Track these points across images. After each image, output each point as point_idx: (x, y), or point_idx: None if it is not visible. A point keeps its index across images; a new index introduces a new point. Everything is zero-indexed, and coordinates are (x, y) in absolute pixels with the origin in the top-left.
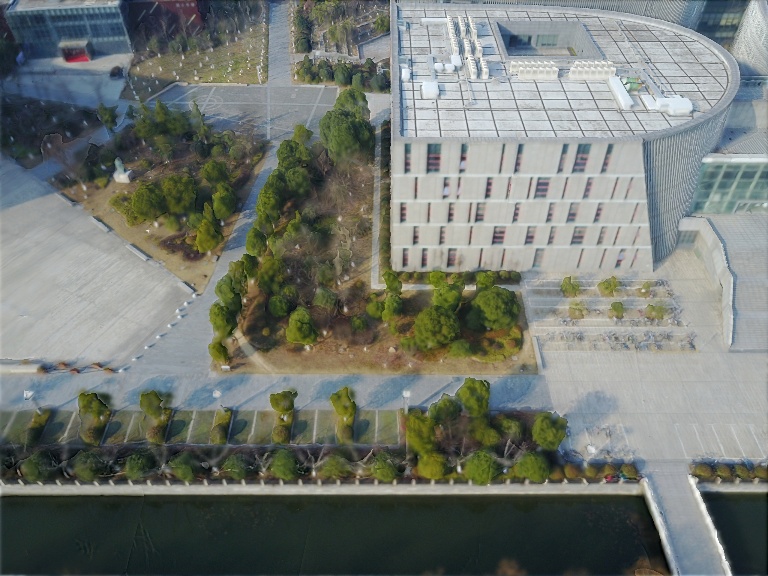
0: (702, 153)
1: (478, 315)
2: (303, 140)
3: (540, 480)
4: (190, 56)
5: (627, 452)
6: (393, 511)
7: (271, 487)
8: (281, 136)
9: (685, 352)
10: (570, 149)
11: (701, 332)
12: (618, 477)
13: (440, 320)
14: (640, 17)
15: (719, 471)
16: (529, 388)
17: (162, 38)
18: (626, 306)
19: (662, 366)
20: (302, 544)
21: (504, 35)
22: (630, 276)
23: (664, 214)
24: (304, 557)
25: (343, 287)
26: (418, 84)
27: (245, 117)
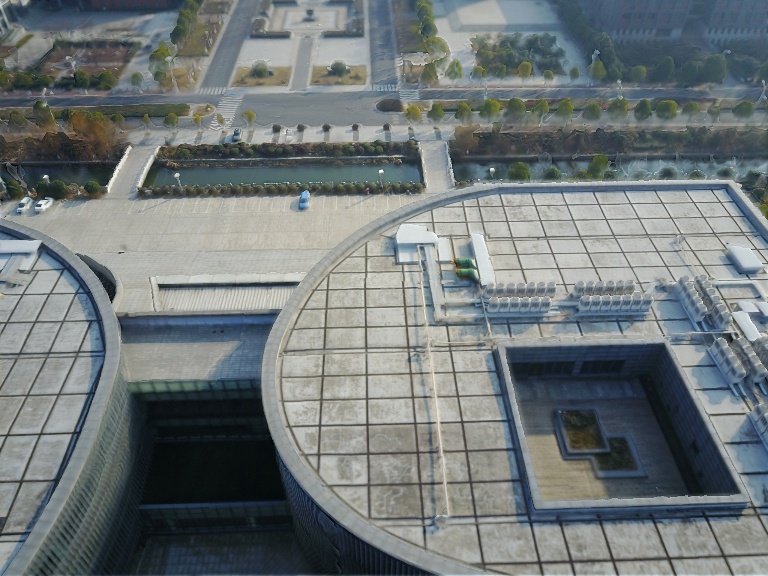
0: None
1: None
2: None
3: None
4: None
5: None
6: None
7: None
8: None
9: None
10: None
11: None
12: (471, 180)
13: None
14: (380, 533)
15: None
16: None
17: None
18: None
19: None
20: None
21: None
22: None
23: None
24: None
25: None
26: None
27: None
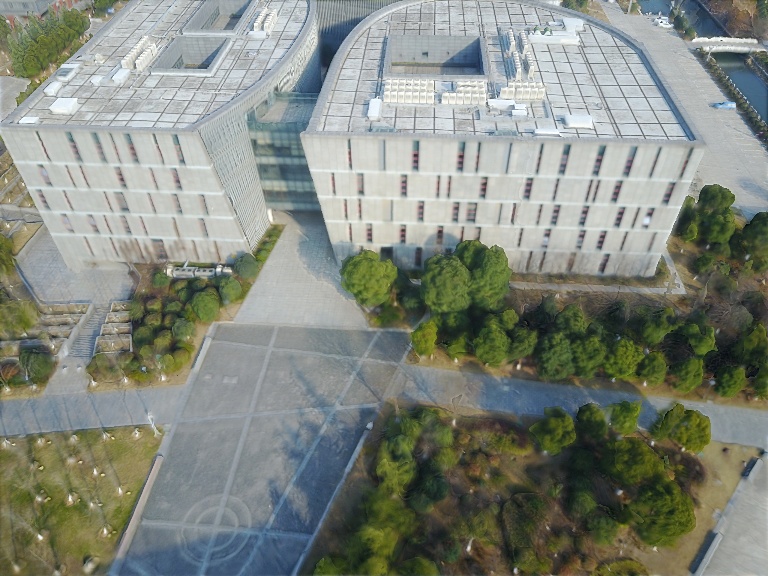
0: None
1: None
2: None
3: None
4: None
5: None
6: None
7: None
8: (371, 388)
9: None
10: None
11: None
12: None
13: None
14: (384, 10)
15: None
16: None
17: None
18: None
19: None
20: None
21: None
22: None
23: None
24: None
25: None
26: (561, 130)
27: (295, 447)
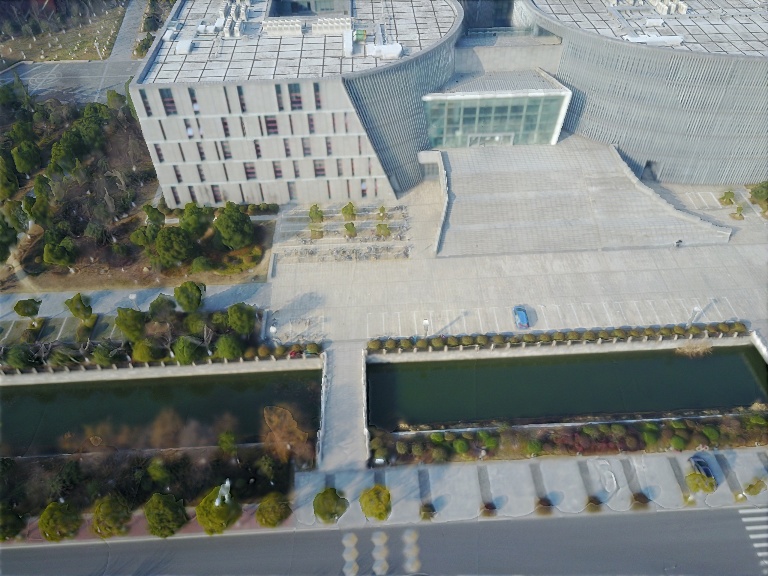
0: (419, 92)
1: (219, 236)
2: (118, 104)
3: (230, 356)
4: (43, 38)
5: (319, 336)
6: (119, 393)
7: (12, 377)
8: (106, 103)
9: (398, 260)
10: (283, 89)
11: (419, 244)
12: (300, 353)
13: (171, 237)
14: None
15: (387, 345)
16: (255, 293)
17: (15, 22)
18: (363, 227)
19: (374, 271)
20: (37, 421)
21: (285, 2)
22: (376, 204)
23: (394, 147)
24: (37, 431)
25: (120, 223)
26: (177, 43)
27: (78, 89)
